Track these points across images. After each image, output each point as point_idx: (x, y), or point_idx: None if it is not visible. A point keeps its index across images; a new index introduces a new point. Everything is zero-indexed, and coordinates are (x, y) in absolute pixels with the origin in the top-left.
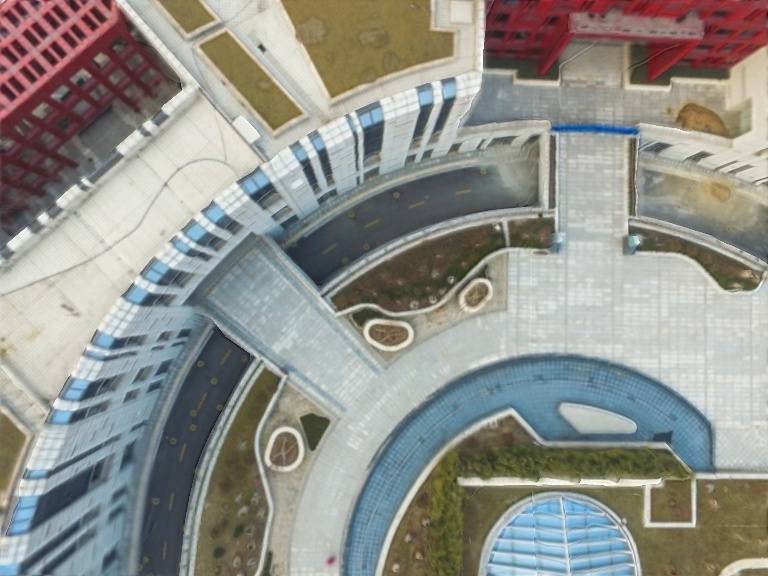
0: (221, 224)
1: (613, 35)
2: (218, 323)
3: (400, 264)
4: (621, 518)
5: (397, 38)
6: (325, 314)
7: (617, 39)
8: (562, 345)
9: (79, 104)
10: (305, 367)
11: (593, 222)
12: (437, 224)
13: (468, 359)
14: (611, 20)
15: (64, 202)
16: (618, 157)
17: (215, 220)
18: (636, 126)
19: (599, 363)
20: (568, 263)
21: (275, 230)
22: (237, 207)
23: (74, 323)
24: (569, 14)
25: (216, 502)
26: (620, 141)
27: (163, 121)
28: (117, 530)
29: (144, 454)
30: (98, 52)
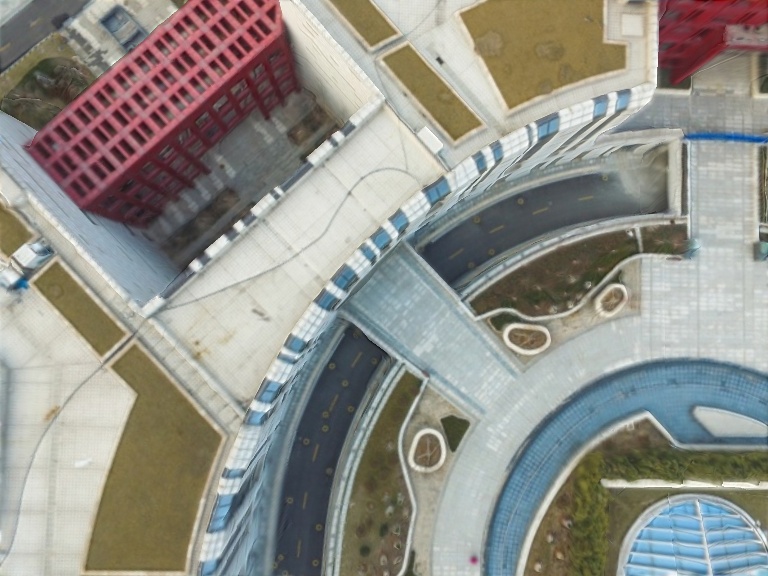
0: (400, 231)
1: (765, 46)
2: (362, 327)
3: (537, 269)
4: (755, 520)
5: (572, 51)
6: (464, 318)
7: (766, 50)
8: (695, 350)
9: (229, 113)
10: (445, 370)
11: (724, 229)
12: (572, 230)
13: (603, 363)
14: (767, 32)
15: (258, 210)
16: (748, 165)
17: (398, 228)
18: (767, 134)
19: (731, 367)
20: (700, 269)
21: (411, 236)
22: (419, 215)
23: (264, 327)
24: (726, 26)
25: (361, 502)
26: (750, 149)
27: (350, 132)
28: (256, 528)
29: (278, 454)
30: (259, 63)
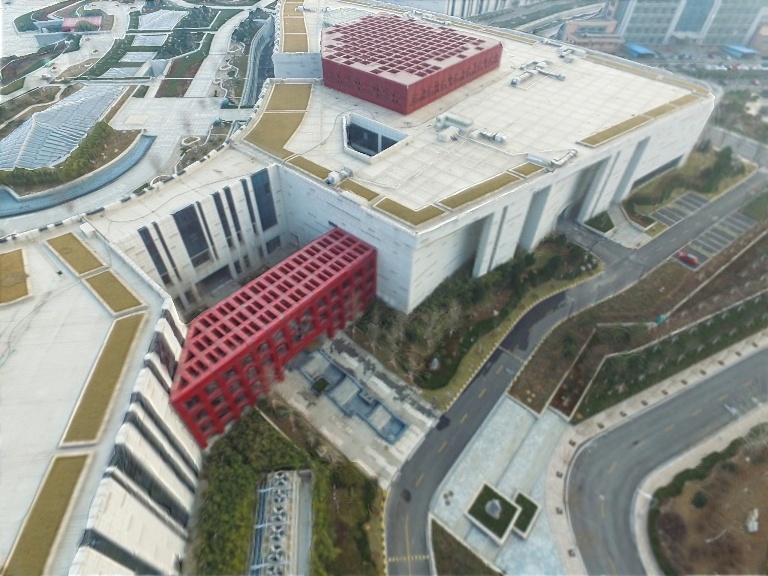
0: None
1: None
2: None
3: None
4: None
5: None
6: None
7: None
8: None
9: None
10: None
11: None
12: None
13: (33, 217)
14: None
15: None
16: None
17: None
18: None
19: None
20: None
21: None
22: None
23: None
24: None
25: None
26: None
27: None
28: None
29: None
30: None
